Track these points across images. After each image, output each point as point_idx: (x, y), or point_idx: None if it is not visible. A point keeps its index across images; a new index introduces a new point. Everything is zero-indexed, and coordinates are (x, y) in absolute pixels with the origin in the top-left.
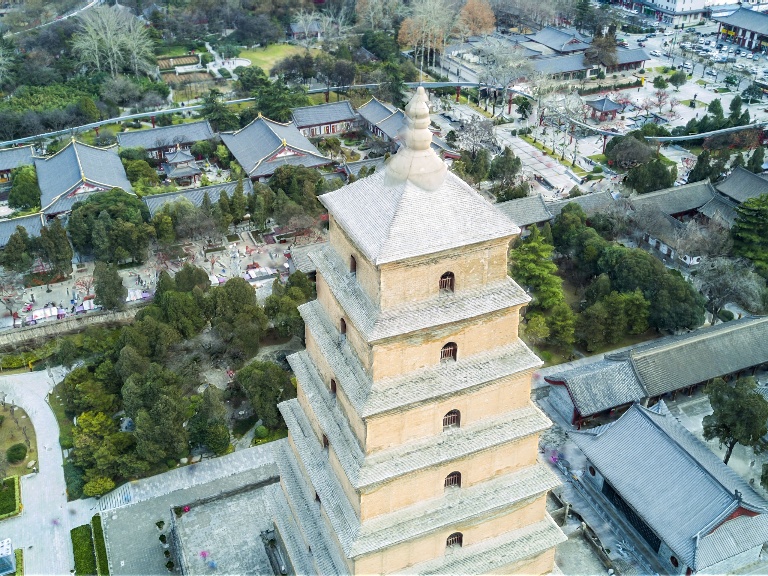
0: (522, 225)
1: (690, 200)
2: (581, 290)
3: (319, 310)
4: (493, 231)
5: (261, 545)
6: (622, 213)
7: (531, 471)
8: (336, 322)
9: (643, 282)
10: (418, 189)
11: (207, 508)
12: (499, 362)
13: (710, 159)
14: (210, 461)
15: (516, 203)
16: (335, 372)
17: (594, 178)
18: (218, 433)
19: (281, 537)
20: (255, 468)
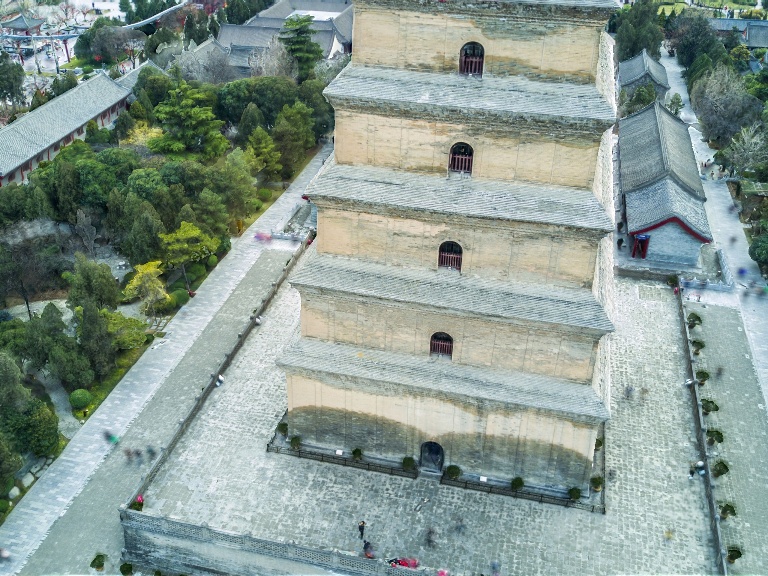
0: (110, 106)
1: None
2: (226, 137)
3: None
4: None
5: (282, 458)
6: (196, 64)
7: None
8: None
9: (289, 97)
10: None
11: (162, 482)
12: None
13: (195, 23)
14: (52, 469)
15: (87, 86)
16: None
17: None
18: (47, 418)
19: (329, 408)
20: (124, 434)
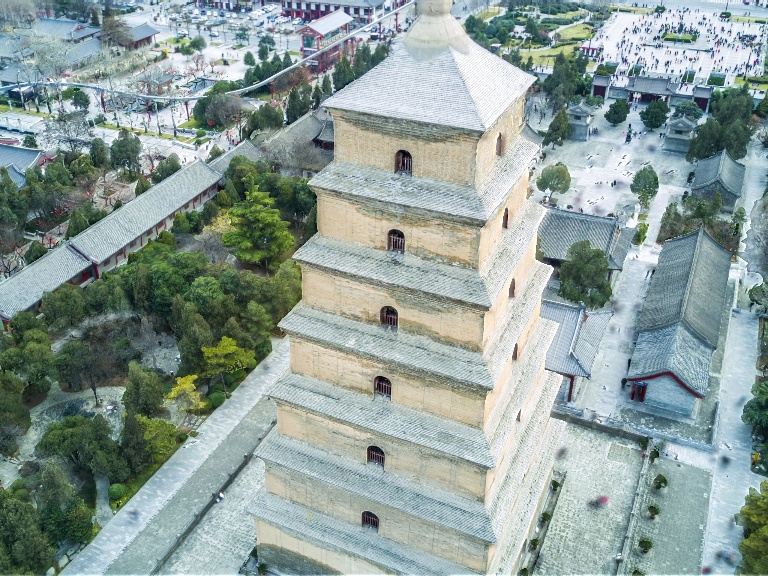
0: (201, 192)
1: (307, 132)
2: (296, 229)
3: (332, 244)
4: (520, 81)
5: None
6: (283, 152)
7: (540, 324)
8: (377, 241)
9: None
10: (459, 53)
11: None
12: (527, 219)
13: (299, 95)
14: (83, 554)
15: (184, 173)
16: (414, 287)
17: (203, 142)
18: (82, 514)
19: (286, 550)
20: (143, 529)
